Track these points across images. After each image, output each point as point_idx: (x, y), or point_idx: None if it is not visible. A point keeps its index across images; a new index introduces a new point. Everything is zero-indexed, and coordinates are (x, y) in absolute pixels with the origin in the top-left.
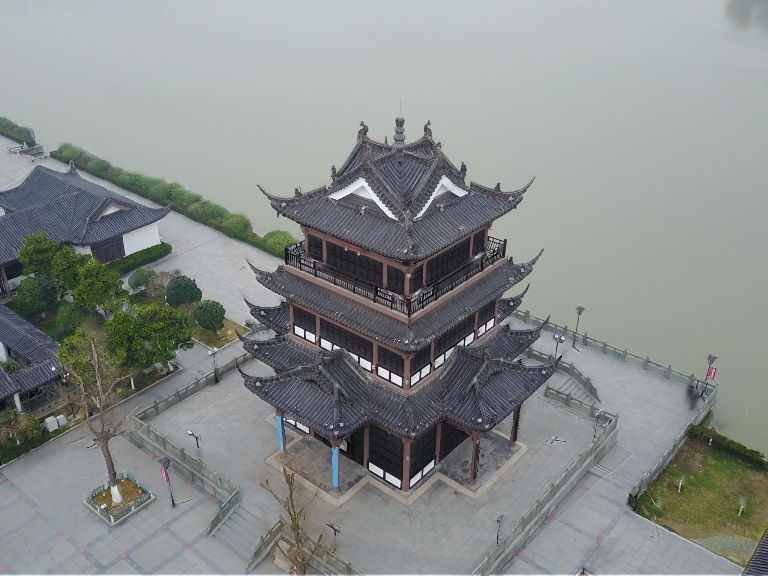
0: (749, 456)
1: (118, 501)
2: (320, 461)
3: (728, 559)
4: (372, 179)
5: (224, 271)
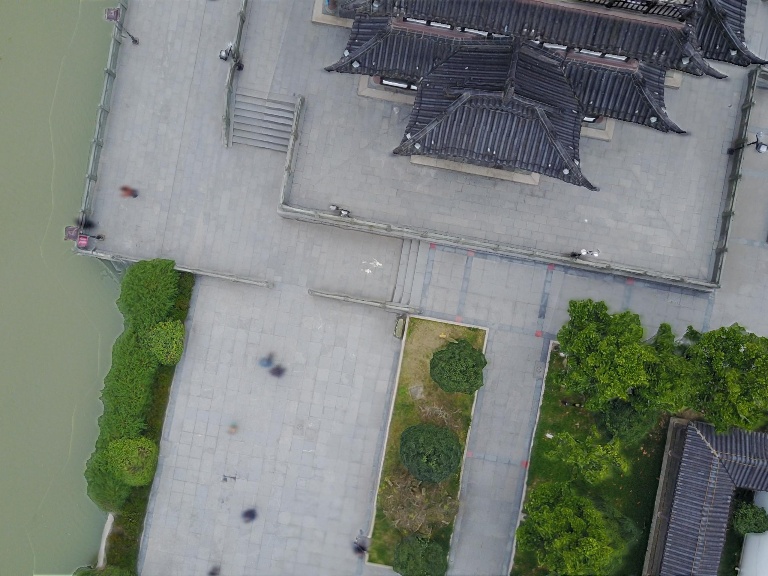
0: None
1: None
2: None
3: None
4: None
5: (258, 500)
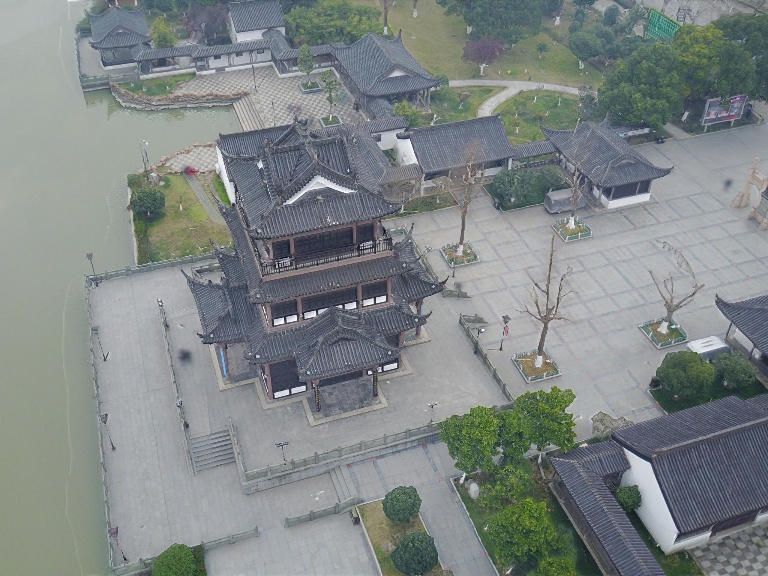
0: None
1: None
2: None
3: None
4: None
5: None
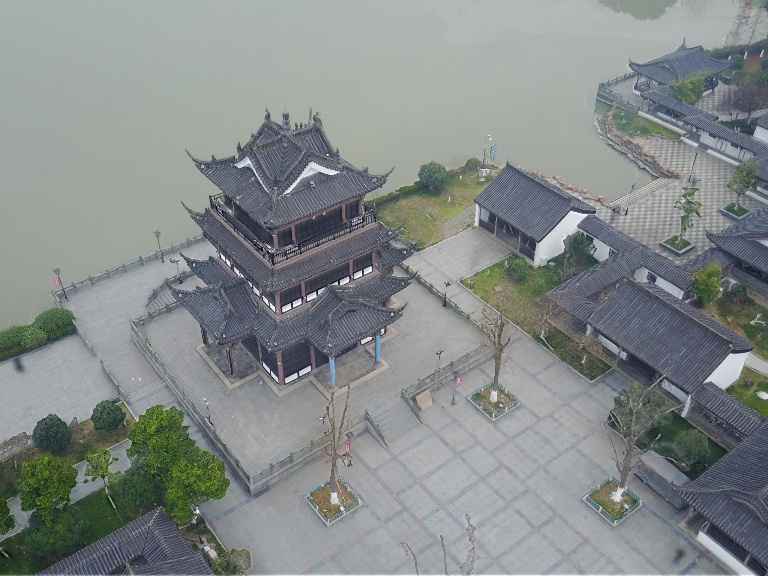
0: (393, 197)
1: (338, 500)
2: (343, 369)
3: (461, 232)
4: (314, 159)
5: None
